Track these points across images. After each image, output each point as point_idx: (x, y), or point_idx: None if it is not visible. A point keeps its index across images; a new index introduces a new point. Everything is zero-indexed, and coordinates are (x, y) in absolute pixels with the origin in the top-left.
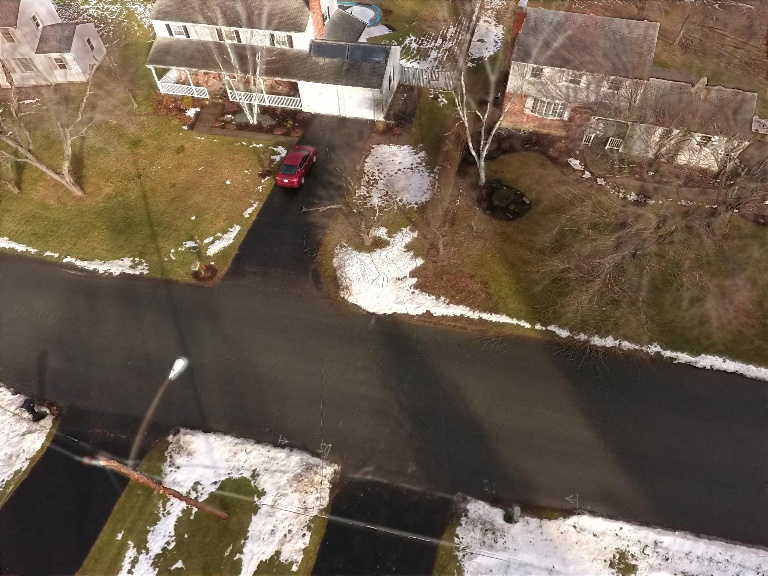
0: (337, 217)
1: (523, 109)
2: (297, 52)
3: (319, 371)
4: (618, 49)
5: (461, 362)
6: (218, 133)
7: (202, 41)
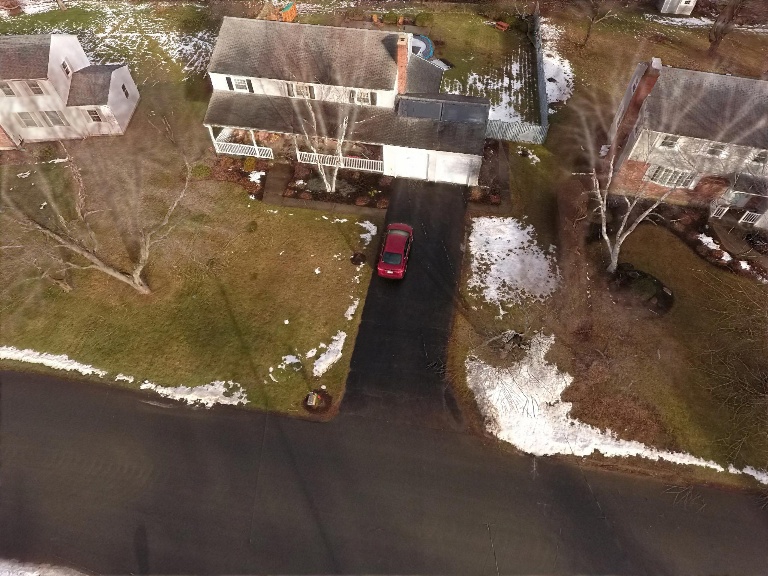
0: (456, 317)
1: (642, 176)
2: (381, 110)
3: (489, 545)
4: (766, 117)
5: (656, 525)
6: (292, 204)
7: (268, 96)
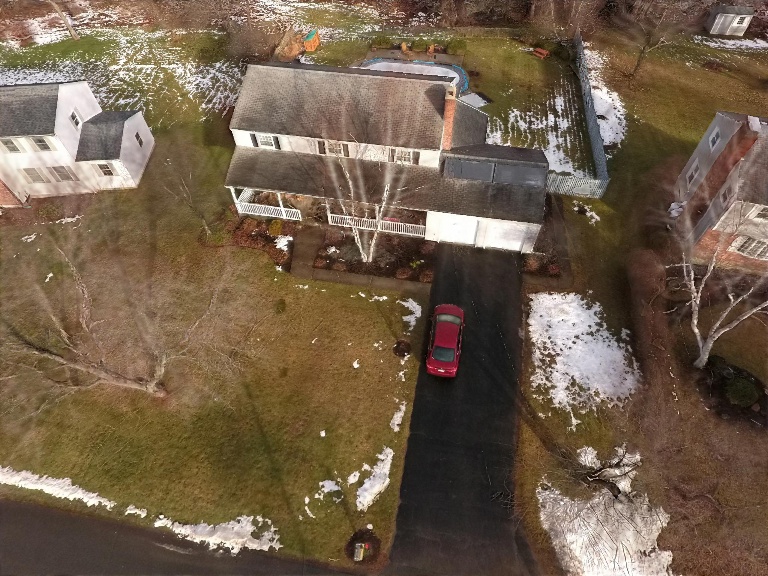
0: (521, 429)
1: (727, 247)
2: (424, 170)
3: None
4: None
5: None
6: (324, 277)
7: (296, 153)
